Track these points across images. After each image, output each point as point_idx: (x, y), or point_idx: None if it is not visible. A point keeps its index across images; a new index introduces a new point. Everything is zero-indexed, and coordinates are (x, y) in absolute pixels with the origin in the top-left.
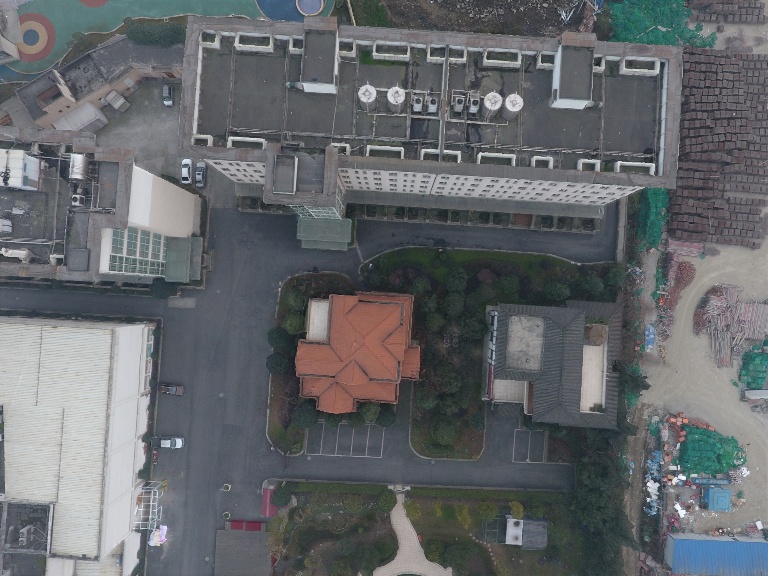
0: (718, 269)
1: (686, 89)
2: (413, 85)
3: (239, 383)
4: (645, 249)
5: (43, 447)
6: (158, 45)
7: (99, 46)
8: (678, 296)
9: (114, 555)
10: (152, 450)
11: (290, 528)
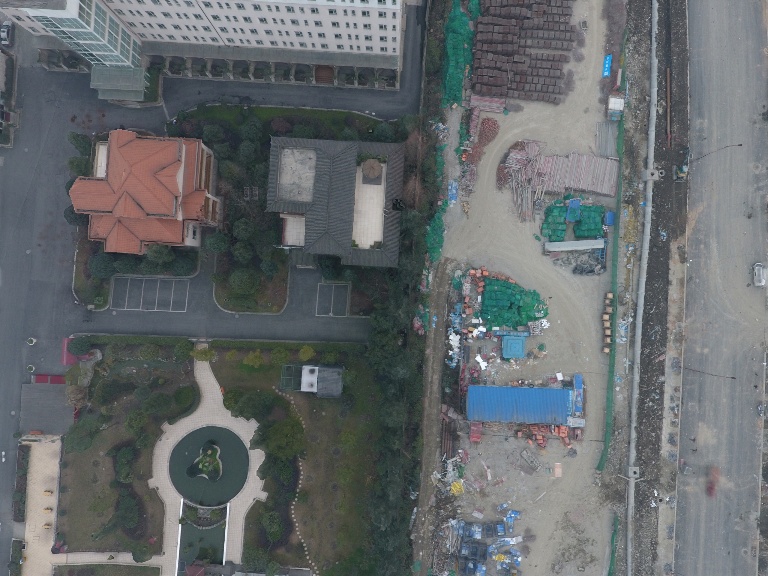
0: (521, 125)
1: None
2: None
3: (46, 240)
4: (449, 106)
5: None
6: None
7: None
8: (481, 152)
9: None
10: None
11: (95, 382)
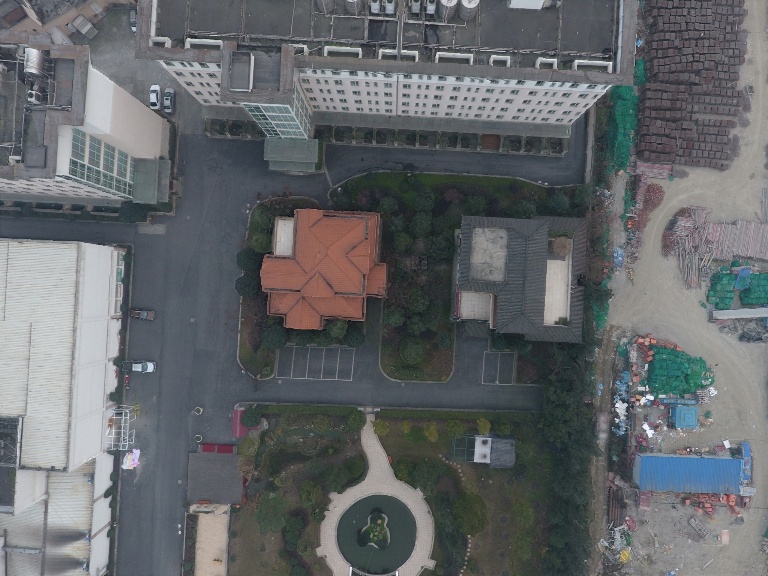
0: (687, 191)
1: (654, 9)
2: None
3: (210, 308)
4: (614, 172)
5: (11, 361)
6: None
7: None
8: (647, 218)
9: (86, 474)
10: (124, 375)
11: (262, 451)
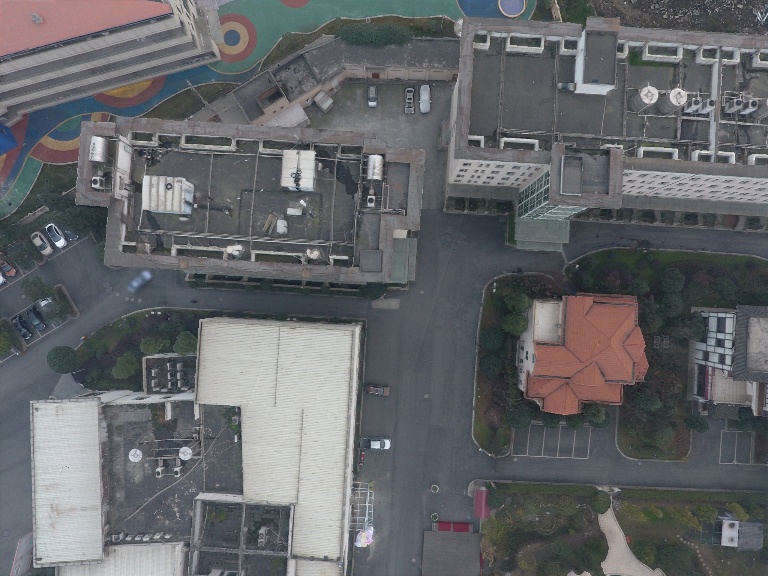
0: None
1: None
2: None
3: (444, 384)
4: None
5: (282, 448)
6: (371, 46)
7: (307, 46)
8: None
9: None
10: (358, 451)
11: None
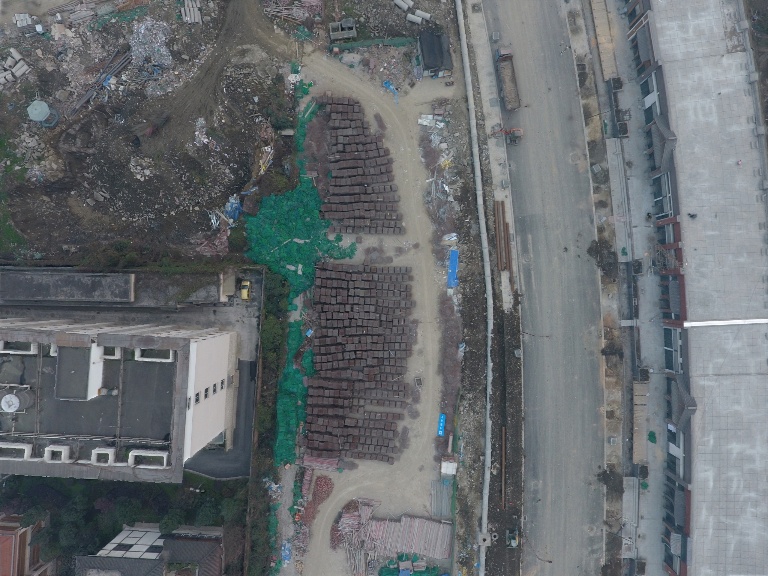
0: (356, 483)
1: (316, 306)
2: None
3: None
4: (283, 463)
5: None
6: None
7: None
8: (315, 511)
9: None
10: None
11: None
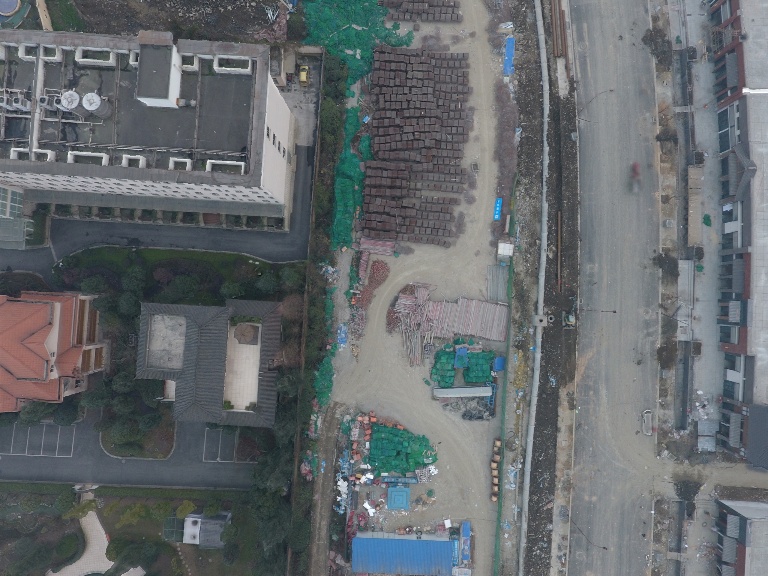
0: (412, 268)
1: (375, 88)
2: (11, 84)
3: None
4: (339, 248)
5: None
6: None
7: None
8: (371, 295)
9: None
10: None
11: None
